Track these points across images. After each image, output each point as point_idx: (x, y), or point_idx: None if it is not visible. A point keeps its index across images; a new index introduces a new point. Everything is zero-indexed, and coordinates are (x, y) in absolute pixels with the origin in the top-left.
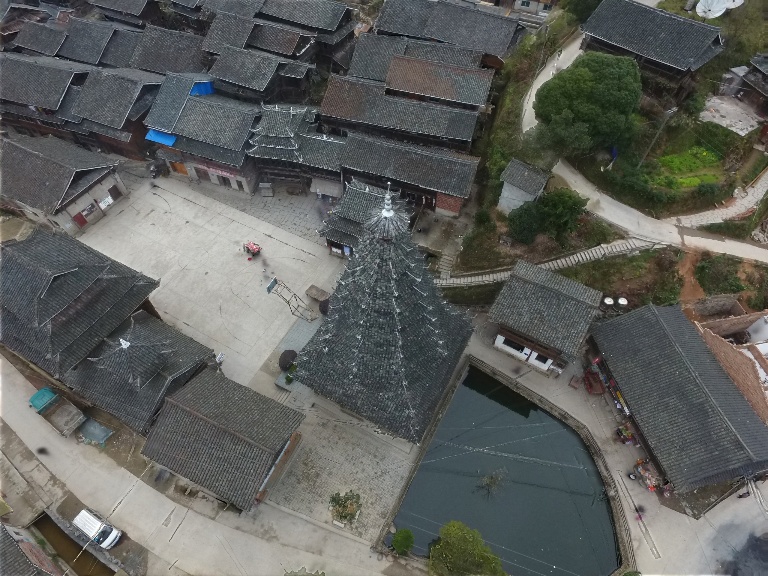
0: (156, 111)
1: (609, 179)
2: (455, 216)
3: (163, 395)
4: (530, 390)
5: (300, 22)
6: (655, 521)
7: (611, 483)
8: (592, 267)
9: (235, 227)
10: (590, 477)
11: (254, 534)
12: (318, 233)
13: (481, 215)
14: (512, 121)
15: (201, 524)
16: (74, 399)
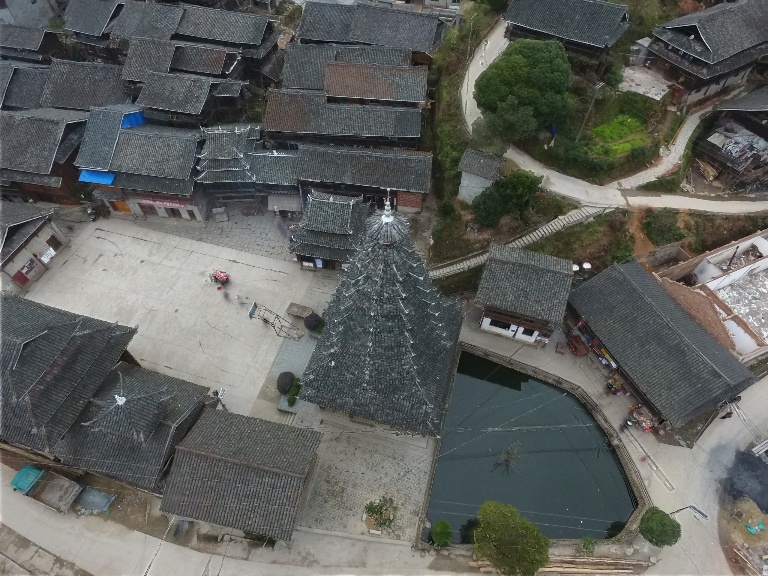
0: (86, 150)
1: (554, 155)
2: (417, 212)
3: (169, 445)
4: (523, 364)
5: (222, 39)
6: (657, 458)
7: (613, 433)
8: (555, 239)
9: (196, 258)
10: (591, 432)
11: (293, 564)
12: (288, 250)
13: (445, 207)
14: (454, 113)
15: (235, 568)
16: (62, 471)
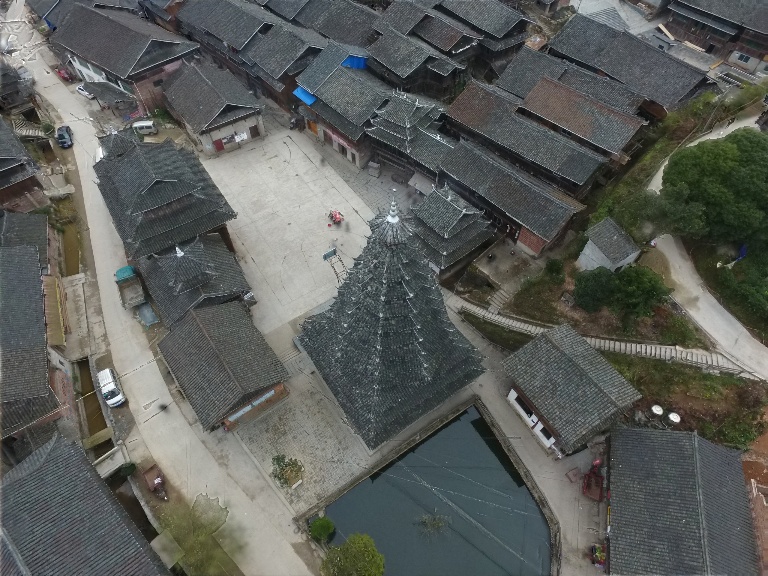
0: (309, 72)
1: (721, 278)
2: (534, 256)
3: (194, 307)
4: (519, 458)
5: (472, 22)
6: None
7: None
8: (653, 365)
9: (332, 193)
10: None
11: (212, 454)
12: None
13: (553, 264)
14: (640, 179)
15: (180, 424)
16: None
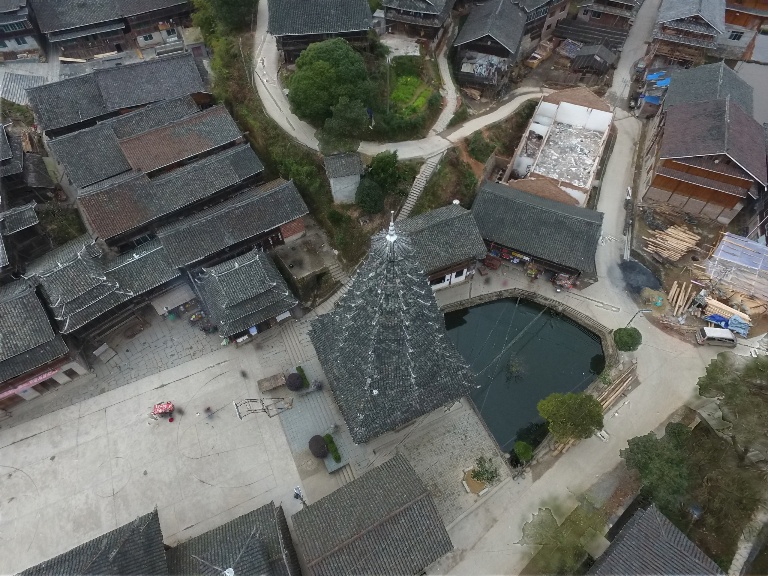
0: None
1: (382, 131)
2: (303, 234)
3: (291, 574)
4: (471, 298)
5: None
6: (588, 301)
7: (555, 304)
8: (425, 195)
9: (115, 412)
10: None
11: (450, 569)
12: (222, 337)
13: (333, 216)
14: (275, 134)
15: None
16: None
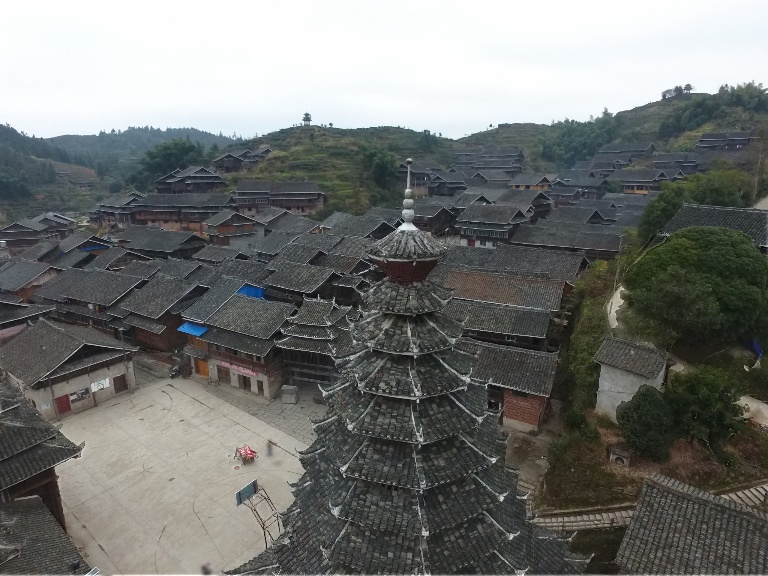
0: (198, 305)
1: (764, 378)
2: (532, 431)
3: None
4: None
5: (363, 257)
6: None
7: None
8: None
9: (236, 430)
10: None
11: None
12: None
13: (572, 416)
14: (596, 325)
15: None
16: None
